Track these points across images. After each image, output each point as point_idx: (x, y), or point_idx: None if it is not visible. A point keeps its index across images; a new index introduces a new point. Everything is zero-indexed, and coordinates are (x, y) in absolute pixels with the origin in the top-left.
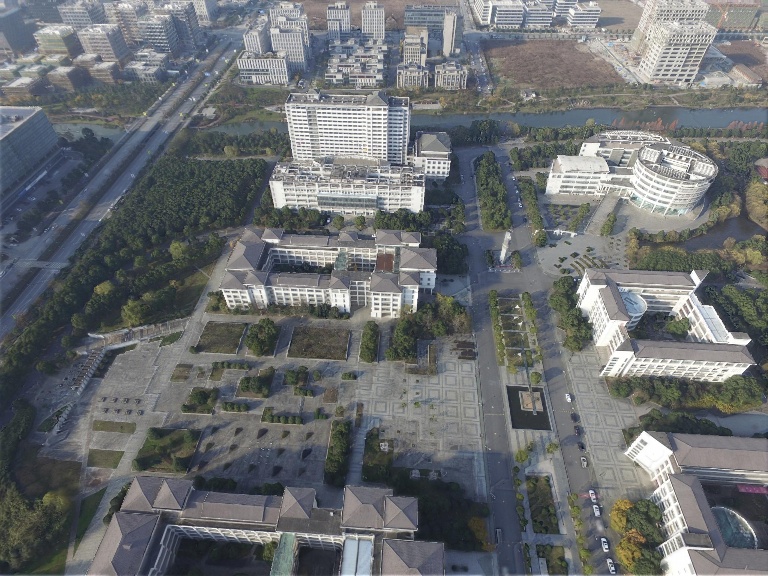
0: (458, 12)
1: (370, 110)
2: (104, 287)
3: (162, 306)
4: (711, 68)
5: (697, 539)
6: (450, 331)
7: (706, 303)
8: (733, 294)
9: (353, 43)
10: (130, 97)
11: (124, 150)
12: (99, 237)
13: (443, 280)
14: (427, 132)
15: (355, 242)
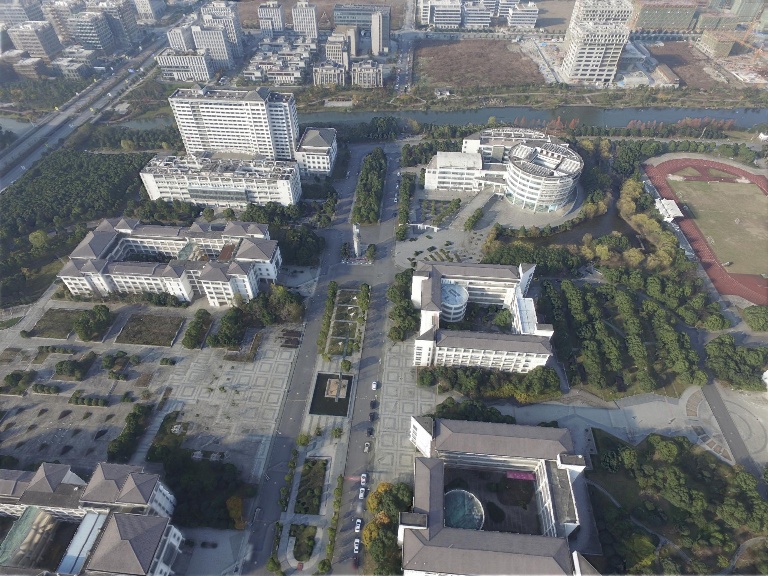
0: (386, 11)
1: (248, 105)
2: None
3: (7, 292)
4: (633, 68)
5: (414, 518)
6: (282, 320)
7: None
8: (568, 288)
9: (282, 41)
10: (49, 92)
11: None
12: None
13: (293, 271)
14: (316, 128)
15: (204, 233)
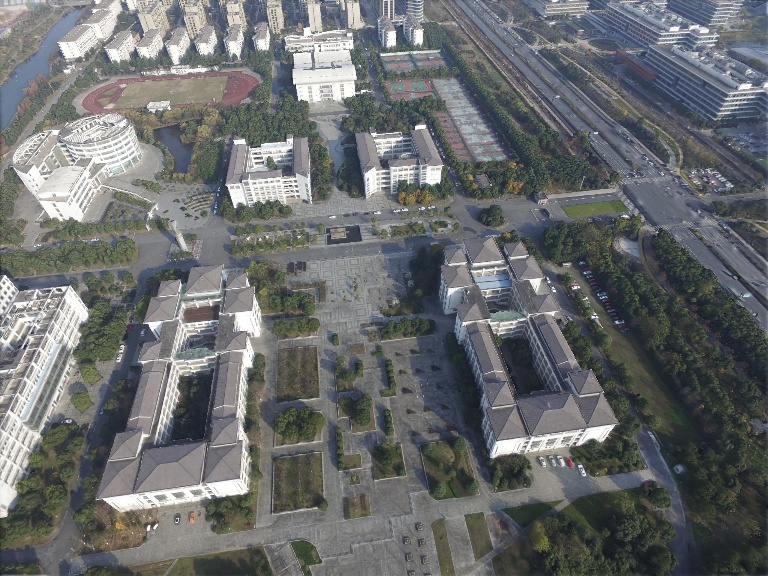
0: None
1: None
2: None
3: None
4: None
5: (422, 161)
6: None
7: None
8: None
9: None
10: None
11: None
12: None
13: None
14: None
15: (164, 341)
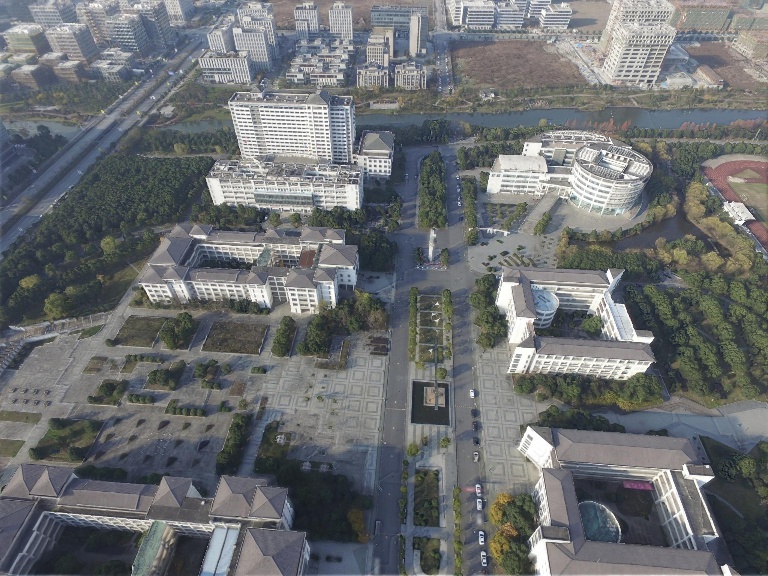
0: (424, 12)
1: (310, 109)
2: (29, 281)
3: (85, 300)
4: (675, 69)
5: (556, 532)
6: (367, 327)
7: (626, 302)
8: (652, 293)
9: (320, 43)
10: (91, 95)
11: (77, 147)
12: (35, 232)
13: (369, 277)
14: (373, 131)
15: (280, 238)
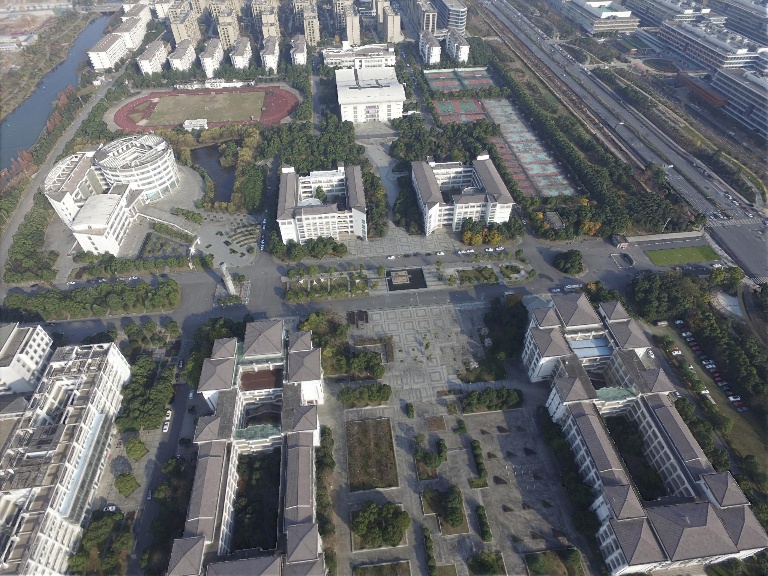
0: None
1: None
2: None
3: None
4: None
5: (491, 199)
6: (336, 330)
7: None
8: None
9: None
10: None
11: None
12: None
13: None
14: None
15: (222, 416)
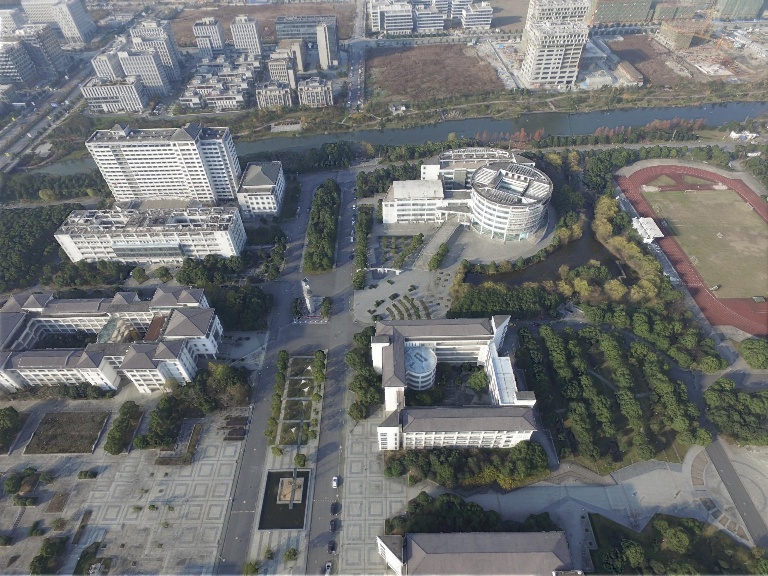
0: (332, 22)
1: (176, 146)
2: None
3: None
4: (595, 67)
5: None
6: None
7: None
8: (547, 336)
9: (222, 61)
10: None
11: None
12: None
13: (237, 339)
14: (259, 162)
15: (128, 305)
